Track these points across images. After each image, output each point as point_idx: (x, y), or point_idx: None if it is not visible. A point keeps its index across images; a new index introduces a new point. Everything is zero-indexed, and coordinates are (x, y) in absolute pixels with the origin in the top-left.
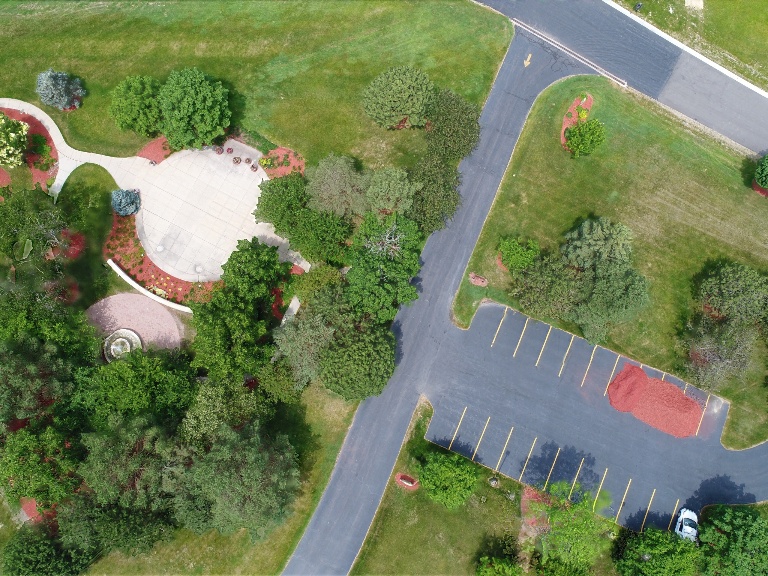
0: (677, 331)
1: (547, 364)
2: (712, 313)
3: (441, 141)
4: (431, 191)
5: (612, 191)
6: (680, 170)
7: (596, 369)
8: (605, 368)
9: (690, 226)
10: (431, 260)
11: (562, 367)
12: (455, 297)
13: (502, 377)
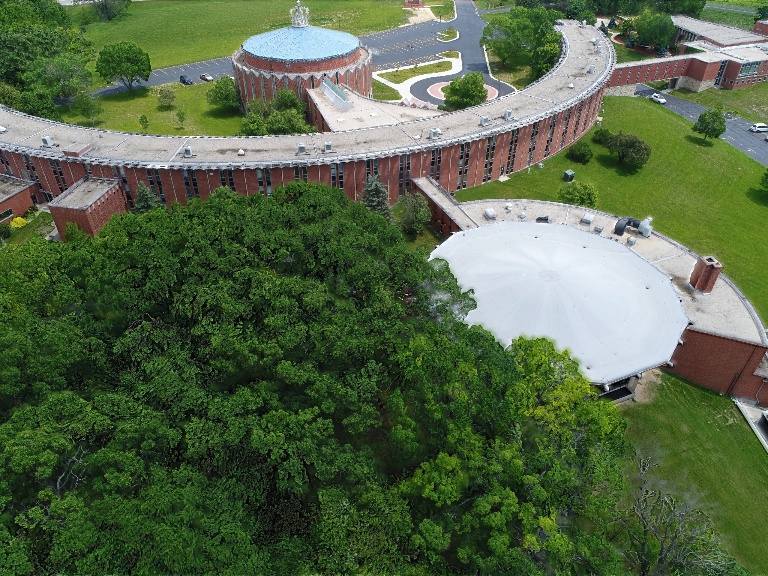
0: None
1: None
2: None
3: None
4: None
5: None
6: None
7: None
8: None
9: None
10: None
11: None
12: None
13: None
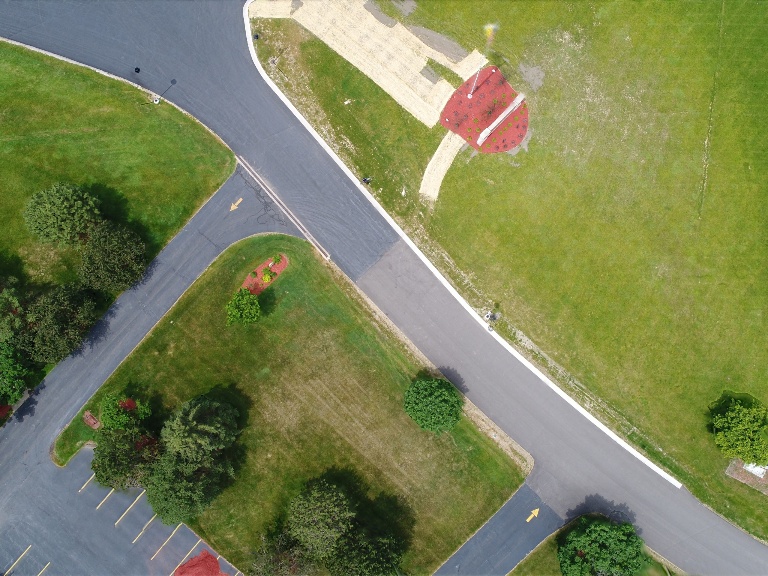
0: (268, 532)
1: (126, 526)
2: (289, 532)
3: None
4: (42, 327)
5: (265, 367)
6: (346, 364)
7: (172, 546)
8: (181, 548)
9: (330, 426)
10: (53, 386)
11: (140, 534)
12: (62, 430)
13: (77, 526)
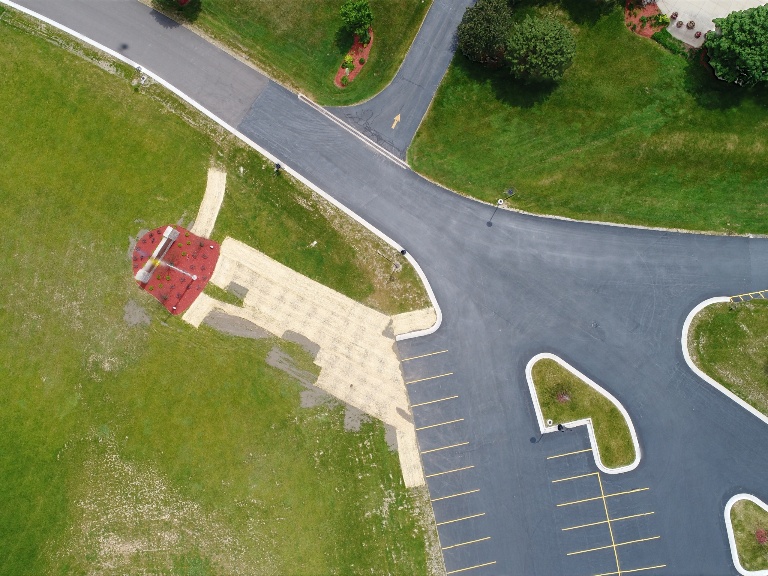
0: None
1: None
2: None
3: (503, 1)
4: None
5: None
6: (261, 7)
7: None
8: None
9: None
10: None
11: None
12: None
13: None
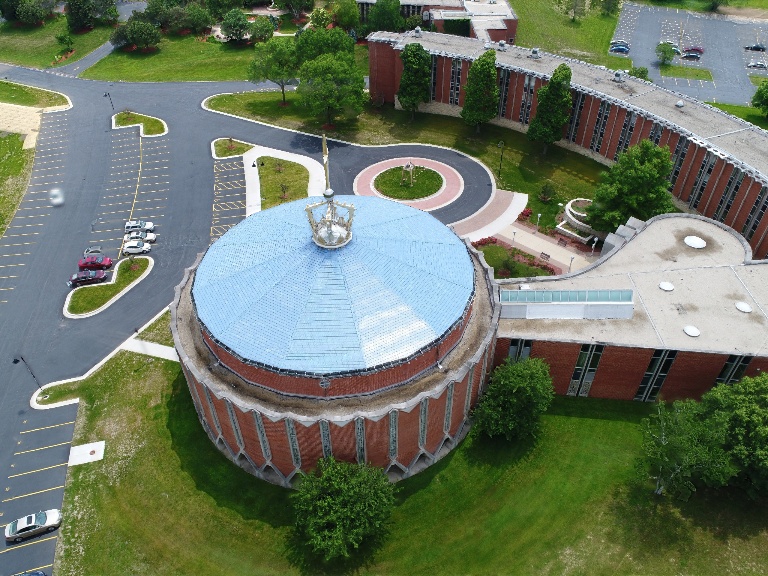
0: None
1: None
2: (43, 12)
3: None
4: None
5: None
6: None
7: None
8: None
9: None
10: None
11: None
12: None
13: None
